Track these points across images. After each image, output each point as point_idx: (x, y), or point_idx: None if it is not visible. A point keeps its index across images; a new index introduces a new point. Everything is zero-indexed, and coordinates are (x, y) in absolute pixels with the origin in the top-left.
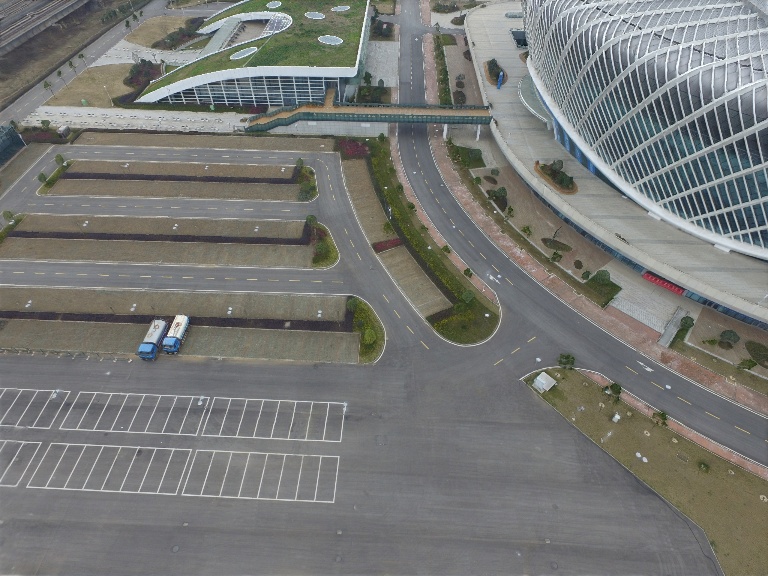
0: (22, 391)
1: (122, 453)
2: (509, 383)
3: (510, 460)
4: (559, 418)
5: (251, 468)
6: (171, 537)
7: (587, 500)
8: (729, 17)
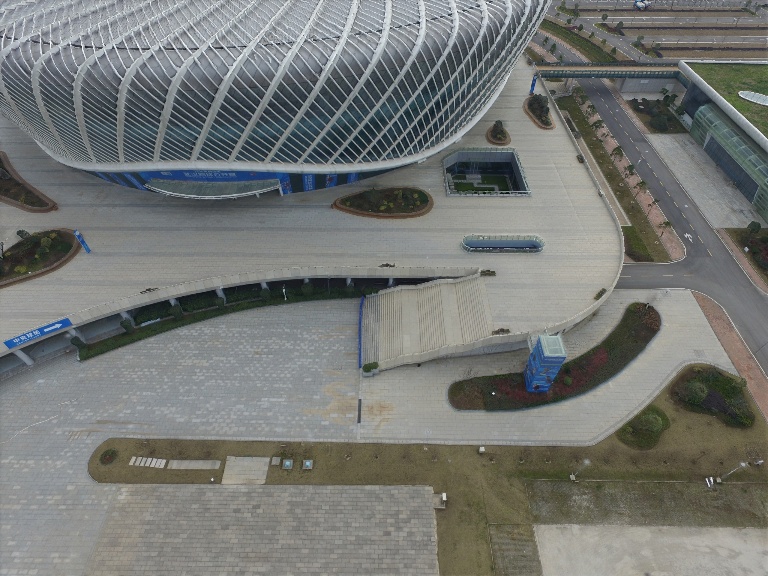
0: None
1: None
2: None
3: None
4: None
5: None
6: None
7: None
8: None
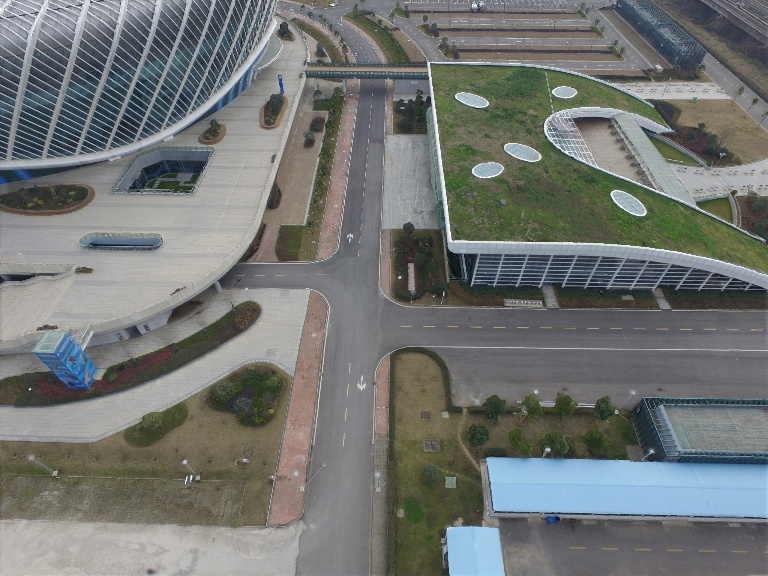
0: None
1: None
2: (346, 5)
3: None
4: (333, 0)
5: None
6: None
7: None
8: None
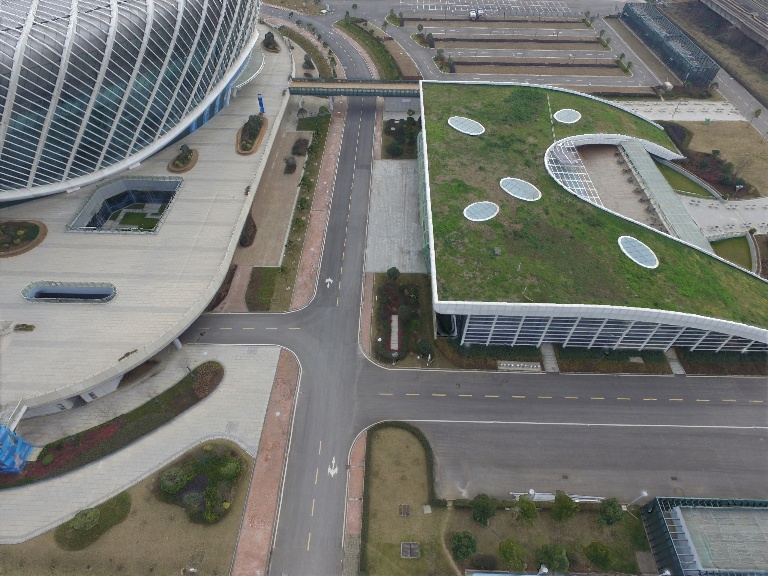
0: None
1: (470, 3)
2: None
3: None
4: (324, 6)
5: (428, 1)
6: None
7: None
8: None
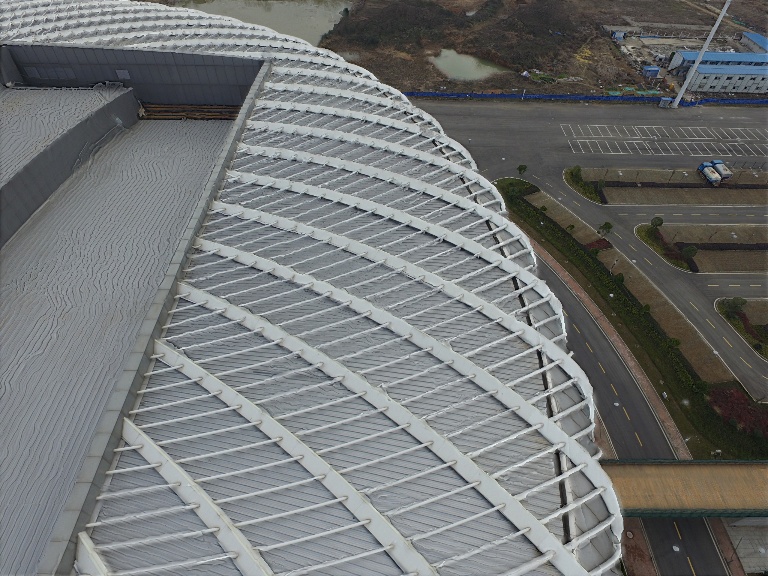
0: (766, 155)
1: None
2: (478, 161)
3: (478, 135)
4: None
5: None
6: (625, 117)
7: (442, 125)
8: (305, 85)
